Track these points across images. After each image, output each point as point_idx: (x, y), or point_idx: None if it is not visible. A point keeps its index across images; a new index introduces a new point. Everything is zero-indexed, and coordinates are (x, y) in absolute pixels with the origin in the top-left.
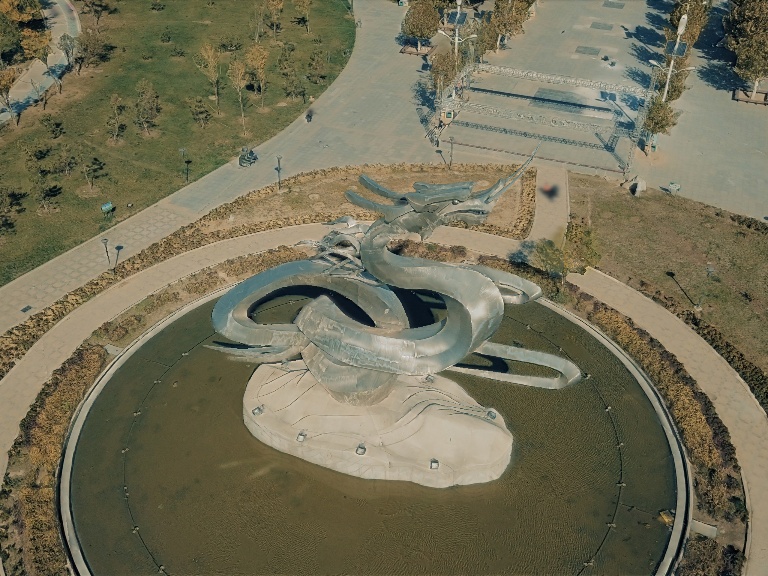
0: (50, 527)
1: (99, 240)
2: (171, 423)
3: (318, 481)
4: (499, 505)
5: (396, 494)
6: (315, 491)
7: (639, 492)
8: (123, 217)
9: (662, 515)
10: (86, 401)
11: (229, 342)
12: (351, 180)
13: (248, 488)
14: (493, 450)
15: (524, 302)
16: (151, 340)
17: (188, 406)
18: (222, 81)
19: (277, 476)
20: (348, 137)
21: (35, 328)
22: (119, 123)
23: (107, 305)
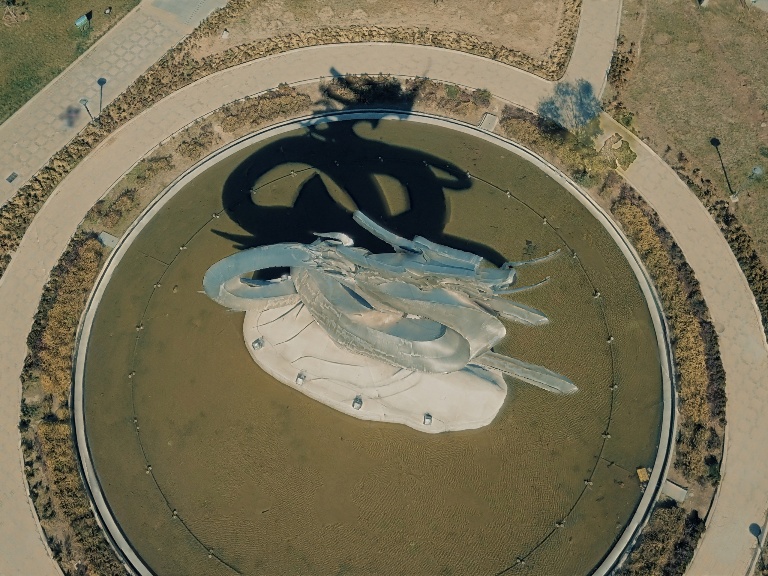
0: (71, 468)
1: (78, 68)
2: (174, 341)
3: (318, 408)
4: (486, 454)
5: (391, 427)
6: (314, 430)
7: (622, 445)
8: (102, 30)
9: (638, 474)
10: (88, 312)
11: (228, 231)
12: None
13: (251, 425)
14: (486, 409)
15: None
16: (147, 227)
17: (189, 319)
18: None
19: (278, 411)
20: None
21: (25, 209)
22: None
23: (96, 173)
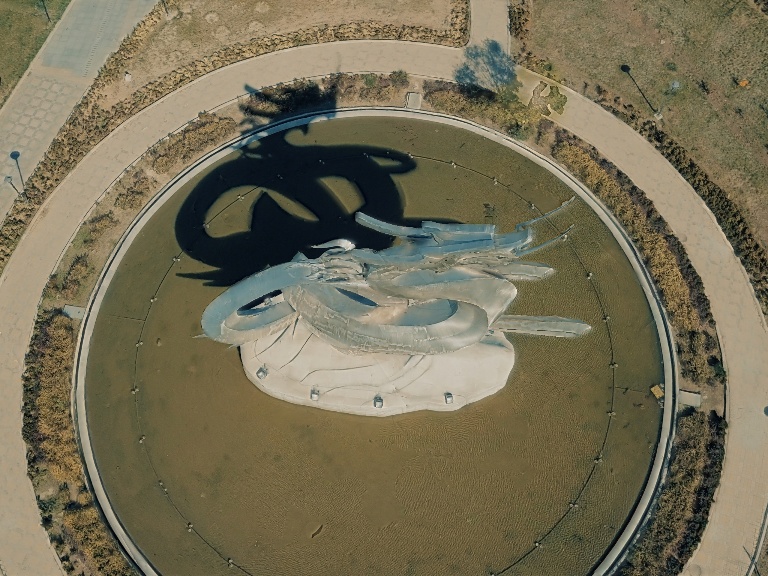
0: (111, 550)
1: None
2: (174, 394)
3: (335, 418)
4: (511, 415)
5: (412, 417)
6: (341, 441)
7: (630, 370)
8: None
9: (653, 392)
10: (77, 390)
11: (193, 272)
12: None
13: (277, 454)
14: (500, 372)
15: None
16: (109, 289)
17: (183, 368)
18: None
19: (300, 433)
20: None
21: None
22: None
23: (40, 249)
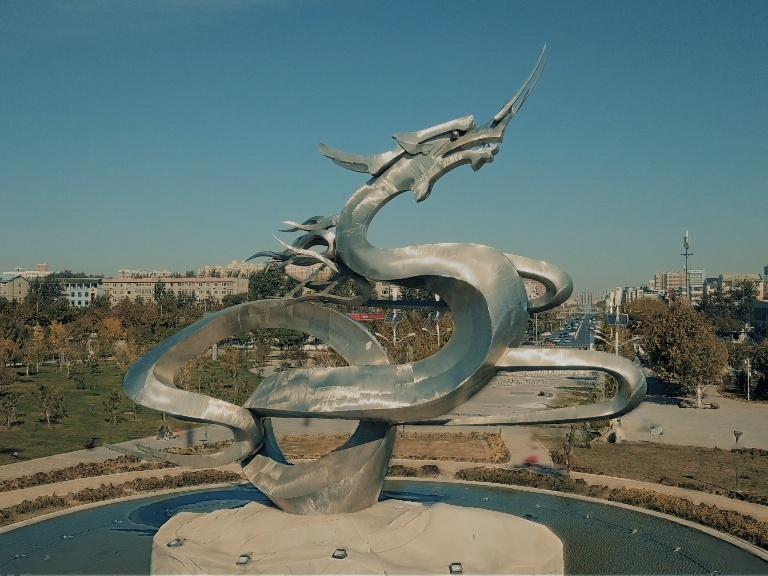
0: None
1: None
2: None
3: None
4: None
5: None
6: None
7: None
8: (4, 463)
9: None
10: None
11: (133, 528)
12: (290, 443)
13: None
14: (539, 548)
15: (550, 300)
16: (19, 529)
17: (64, 572)
18: (140, 406)
19: None
20: (283, 427)
21: None
22: (16, 420)
23: None
